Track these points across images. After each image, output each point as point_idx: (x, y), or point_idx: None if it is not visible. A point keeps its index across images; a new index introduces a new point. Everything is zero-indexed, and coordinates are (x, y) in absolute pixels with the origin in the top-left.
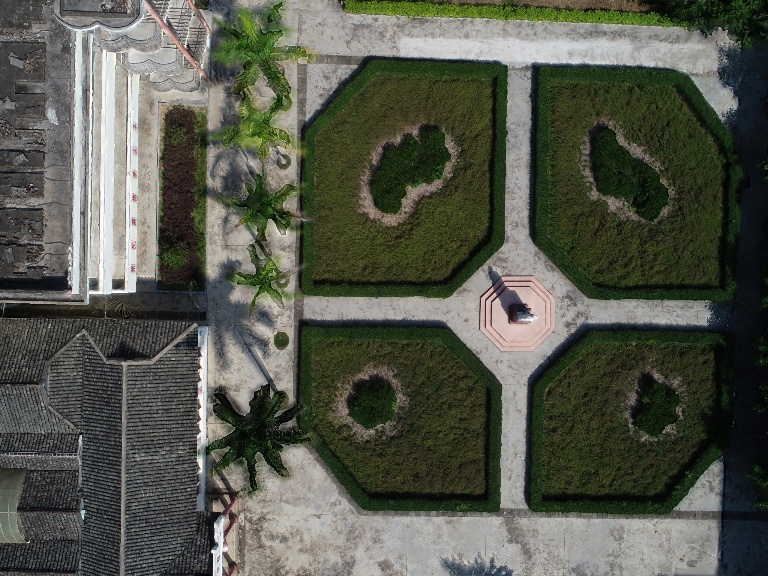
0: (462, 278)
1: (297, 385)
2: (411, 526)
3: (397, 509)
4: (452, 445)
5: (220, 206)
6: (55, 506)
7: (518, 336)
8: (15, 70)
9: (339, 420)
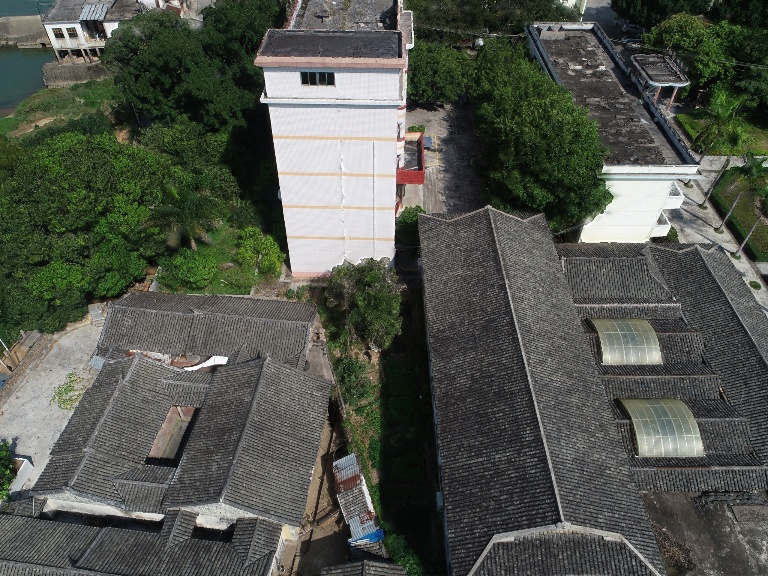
0: None
1: None
2: None
3: None
4: None
5: (675, 225)
6: None
7: None
8: (619, 108)
9: None
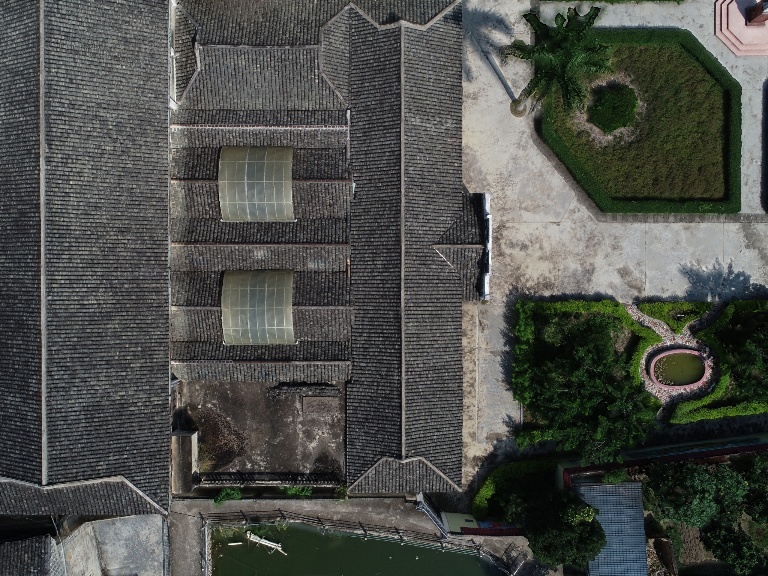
0: None
1: (535, 92)
2: (649, 232)
3: (640, 210)
4: (691, 148)
5: None
6: (328, 177)
7: (755, 38)
8: None
9: (577, 126)
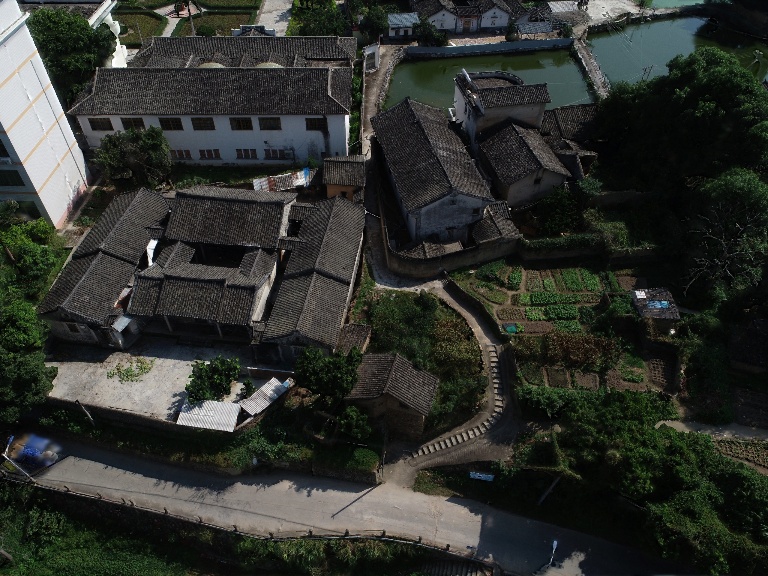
0: (161, 16)
1: None
2: None
3: None
4: None
5: None
6: None
7: None
8: None
9: None
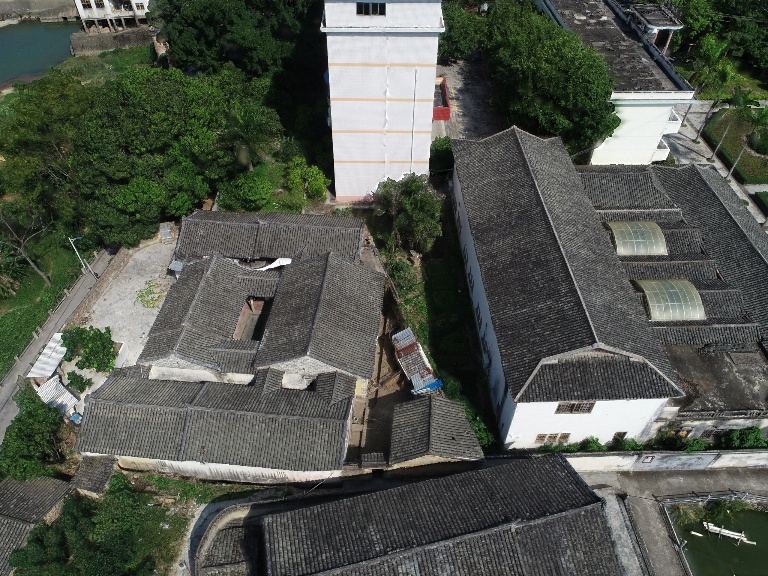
0: None
1: None
2: None
3: None
4: None
5: None
6: None
7: None
8: None
9: None
